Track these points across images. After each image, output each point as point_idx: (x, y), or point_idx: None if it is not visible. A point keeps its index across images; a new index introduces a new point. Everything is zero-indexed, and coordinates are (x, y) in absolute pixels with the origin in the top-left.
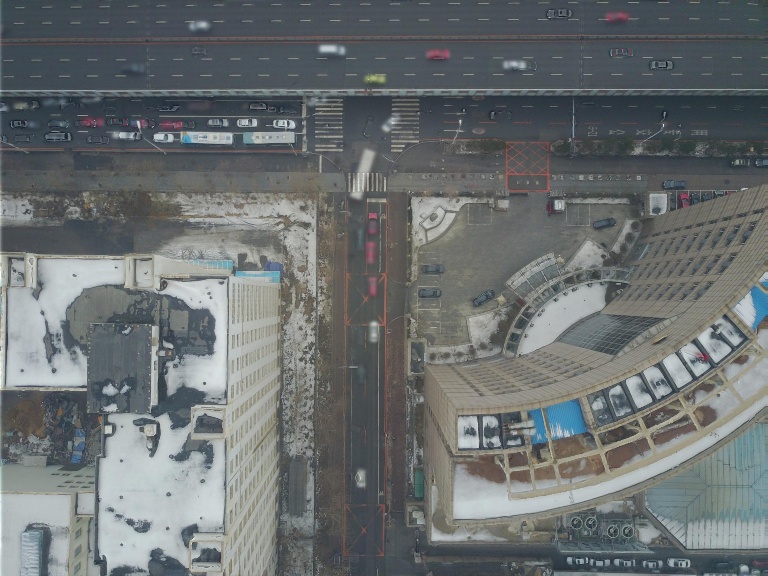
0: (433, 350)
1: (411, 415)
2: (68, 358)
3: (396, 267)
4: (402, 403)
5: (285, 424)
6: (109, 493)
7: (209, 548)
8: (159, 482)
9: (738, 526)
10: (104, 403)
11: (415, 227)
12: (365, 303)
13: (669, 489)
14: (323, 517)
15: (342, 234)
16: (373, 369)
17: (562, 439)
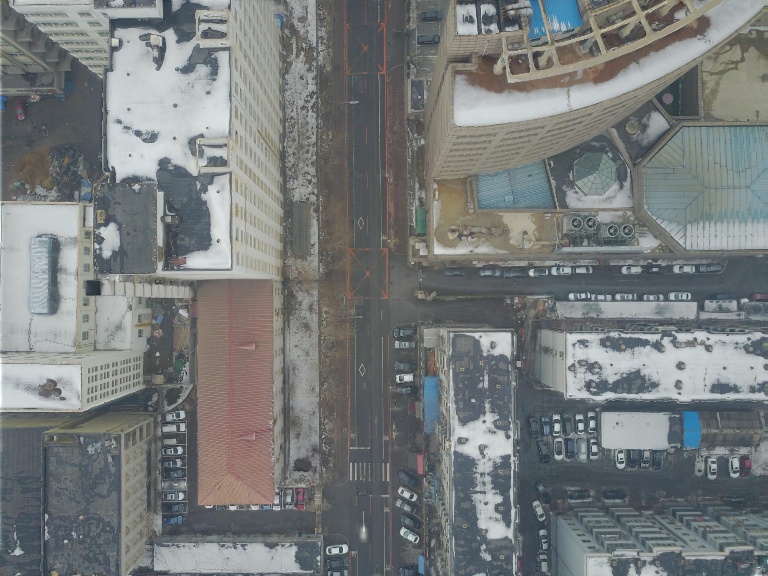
0: None
1: (412, 159)
2: None
3: (395, 16)
4: (403, 148)
5: (288, 171)
6: (117, 105)
7: (215, 156)
8: (165, 94)
9: (736, 227)
10: None
11: None
12: (365, 52)
13: (667, 192)
14: (327, 261)
15: None
16: (374, 117)
17: None
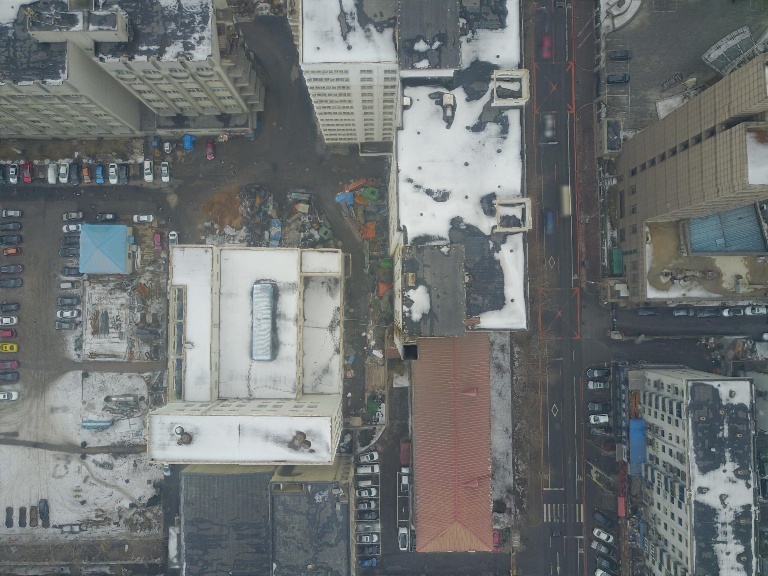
0: (624, 133)
1: (604, 198)
2: (363, 36)
3: (583, 55)
4: (594, 187)
5: None
6: (408, 164)
7: (508, 215)
8: (457, 152)
9: None
10: (416, 59)
11: (603, 13)
12: (553, 91)
13: None
14: None
15: (543, 8)
16: (563, 156)
17: None
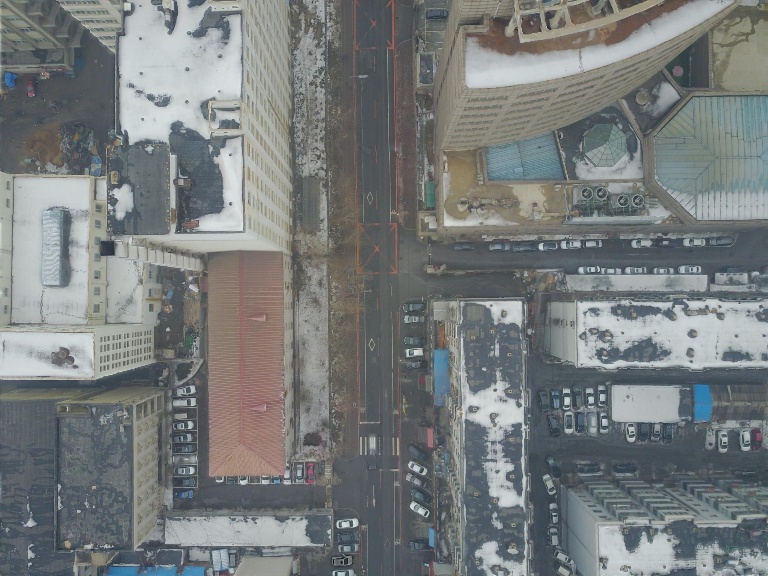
0: None
1: (421, 133)
2: None
3: None
4: (412, 123)
5: (297, 147)
6: (129, 69)
7: (228, 119)
8: (178, 58)
9: (747, 197)
10: None
11: None
12: (373, 27)
13: (678, 162)
14: (336, 236)
15: None
16: (383, 92)
17: (571, 10)
